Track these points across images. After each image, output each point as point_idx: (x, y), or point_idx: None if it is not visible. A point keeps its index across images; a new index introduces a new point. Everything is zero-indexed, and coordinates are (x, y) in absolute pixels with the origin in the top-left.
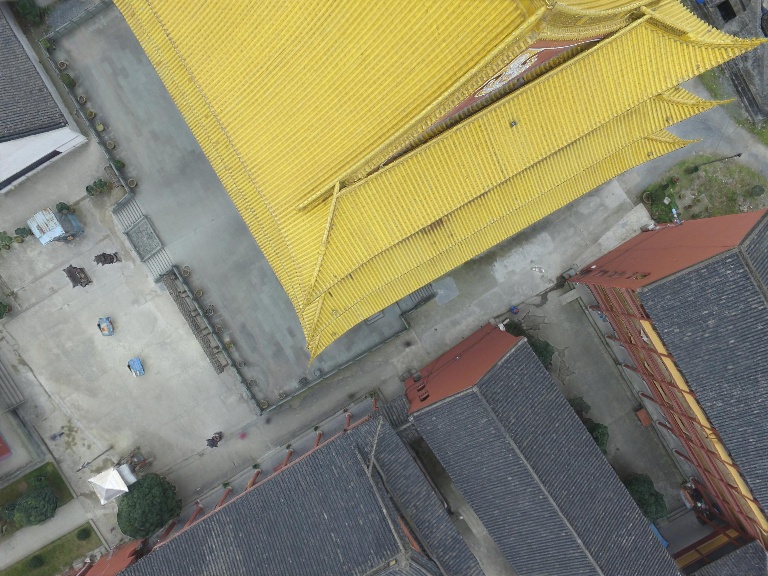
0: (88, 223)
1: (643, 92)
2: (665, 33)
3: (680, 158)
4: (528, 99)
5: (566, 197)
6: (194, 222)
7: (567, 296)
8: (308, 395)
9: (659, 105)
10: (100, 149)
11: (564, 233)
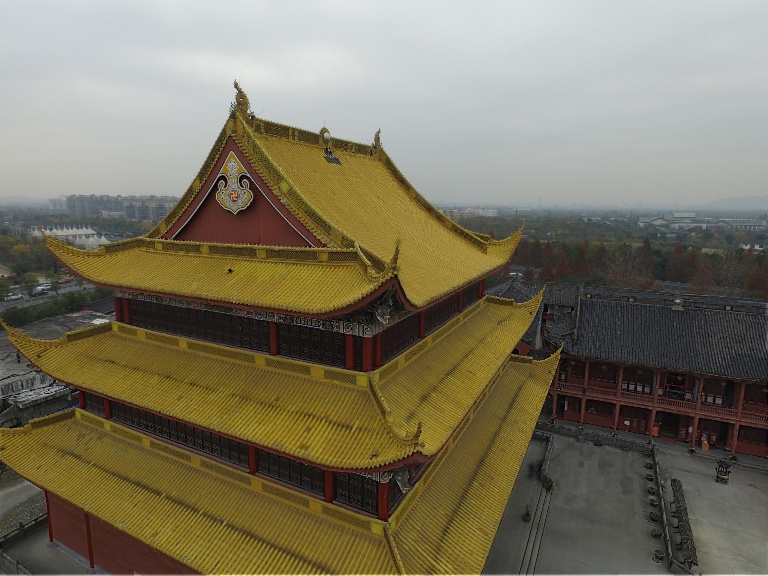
0: None
1: None
2: None
3: None
4: None
5: None
6: None
7: None
8: None
9: None
10: None
11: None
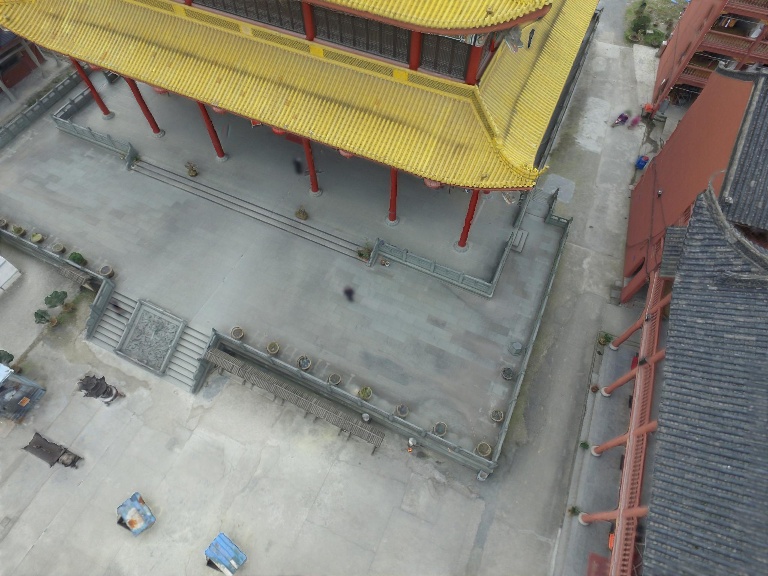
0: (49, 374)
1: None
2: None
3: (623, 10)
4: None
5: None
6: (216, 271)
7: (668, 128)
8: (526, 408)
9: None
10: (42, 275)
11: (605, 90)
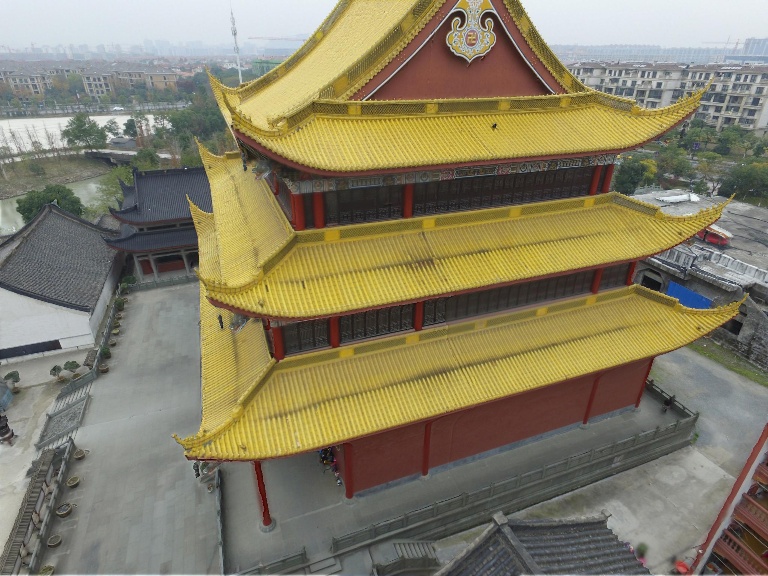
0: (19, 404)
1: (619, 141)
2: (617, 111)
3: None
4: (506, 121)
5: (609, 357)
6: (138, 409)
7: None
8: None
9: (663, 225)
10: None
11: (648, 506)
